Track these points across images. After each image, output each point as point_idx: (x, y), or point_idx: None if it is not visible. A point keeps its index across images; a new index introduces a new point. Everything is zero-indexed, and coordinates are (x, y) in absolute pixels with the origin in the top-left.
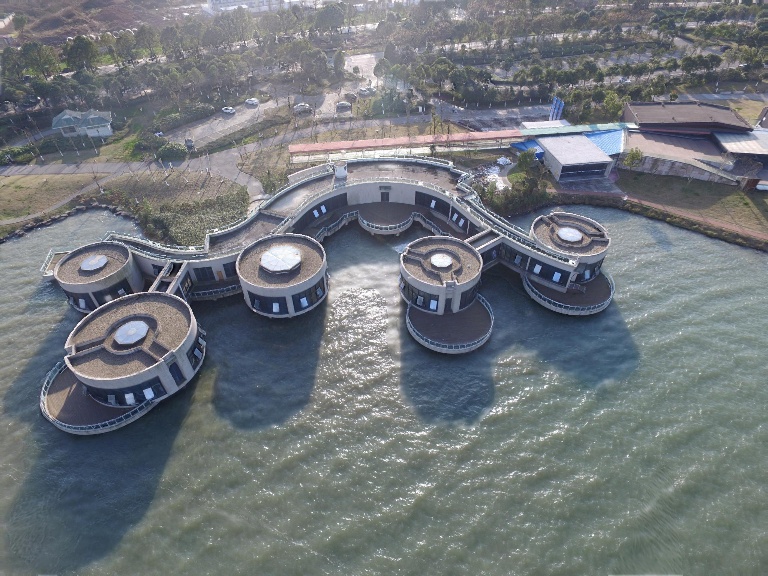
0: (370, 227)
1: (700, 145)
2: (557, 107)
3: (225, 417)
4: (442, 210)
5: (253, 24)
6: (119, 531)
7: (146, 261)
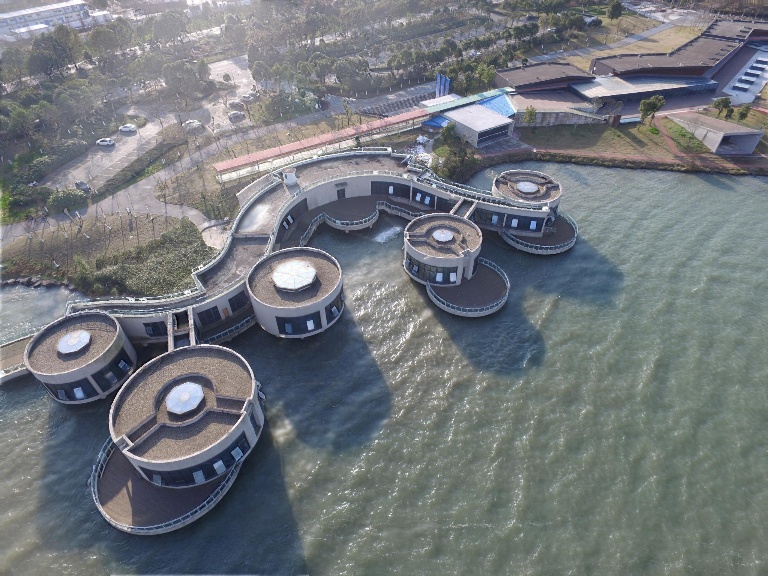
0: (344, 225)
1: (565, 97)
2: (443, 83)
3: (323, 447)
4: (401, 194)
5: (81, 43)
6: None
7: (135, 322)
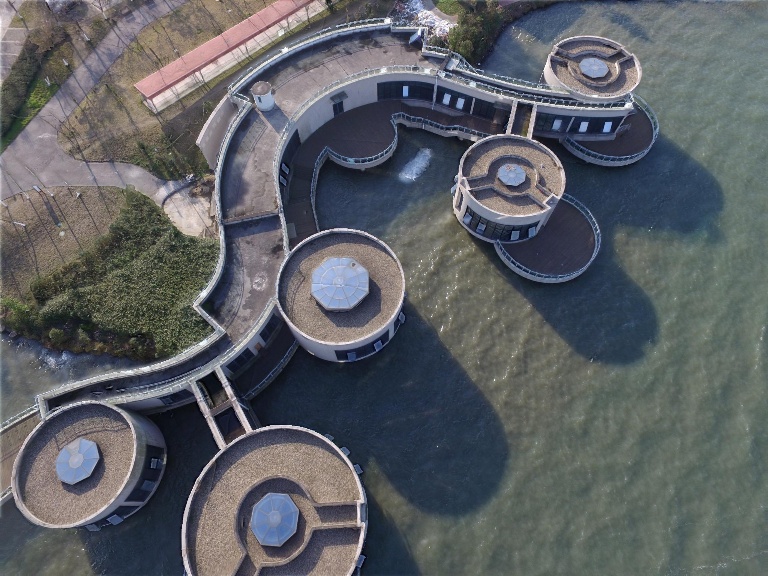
0: (360, 163)
1: None
2: None
3: (444, 507)
4: (419, 95)
5: None
6: None
7: (146, 400)
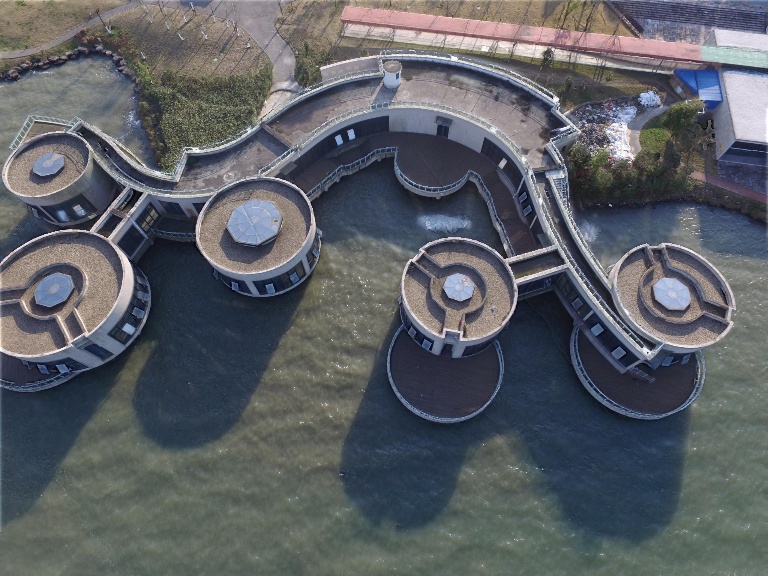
0: (403, 179)
1: None
2: None
3: (142, 414)
4: (512, 176)
5: None
6: (5, 516)
7: None
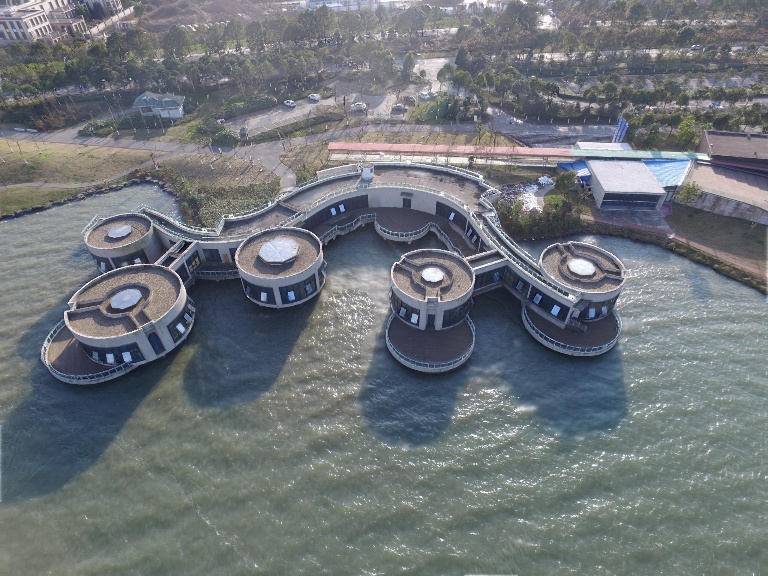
0: (382, 231)
1: None
2: (621, 129)
3: (189, 391)
4: (460, 224)
5: (335, 22)
6: (67, 474)
7: (165, 236)
